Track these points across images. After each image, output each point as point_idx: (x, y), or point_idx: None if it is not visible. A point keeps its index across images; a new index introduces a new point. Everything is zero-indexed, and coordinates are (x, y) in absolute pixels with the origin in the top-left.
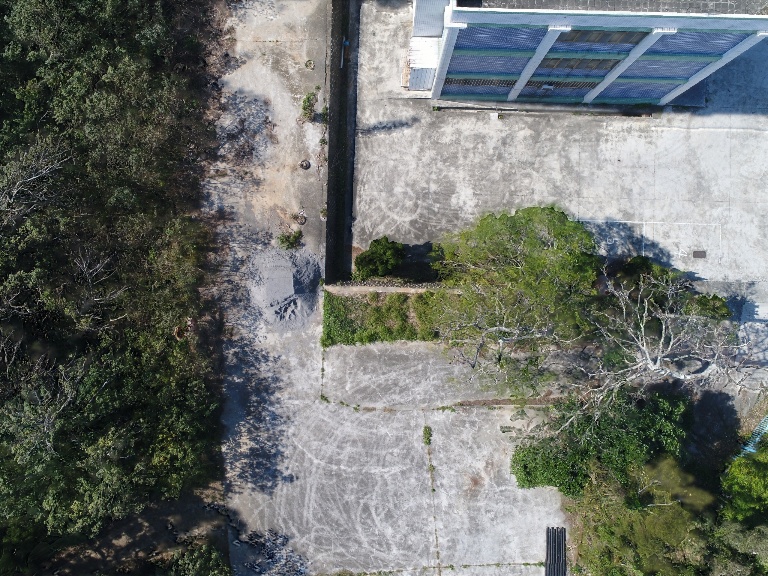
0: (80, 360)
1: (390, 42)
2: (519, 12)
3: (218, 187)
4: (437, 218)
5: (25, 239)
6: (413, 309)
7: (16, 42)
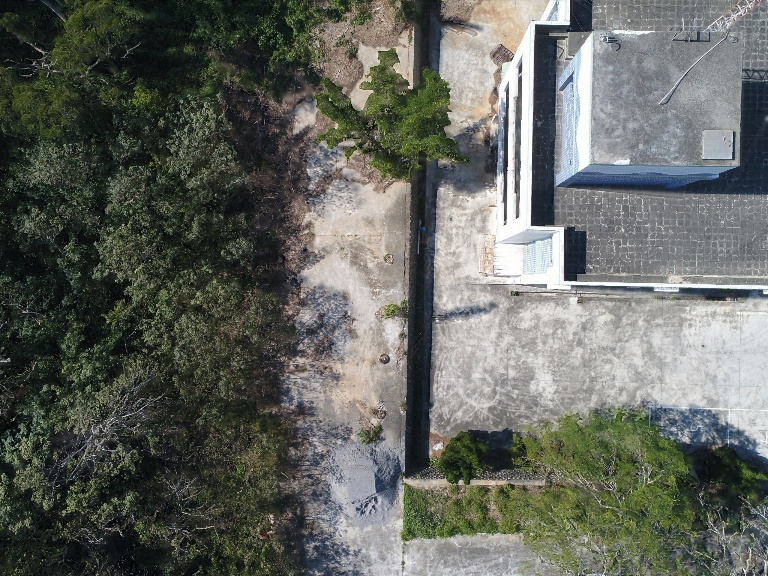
0: (169, 572)
1: (467, 227)
2: None
3: (298, 382)
4: (516, 405)
5: (118, 467)
6: (494, 502)
7: (104, 262)
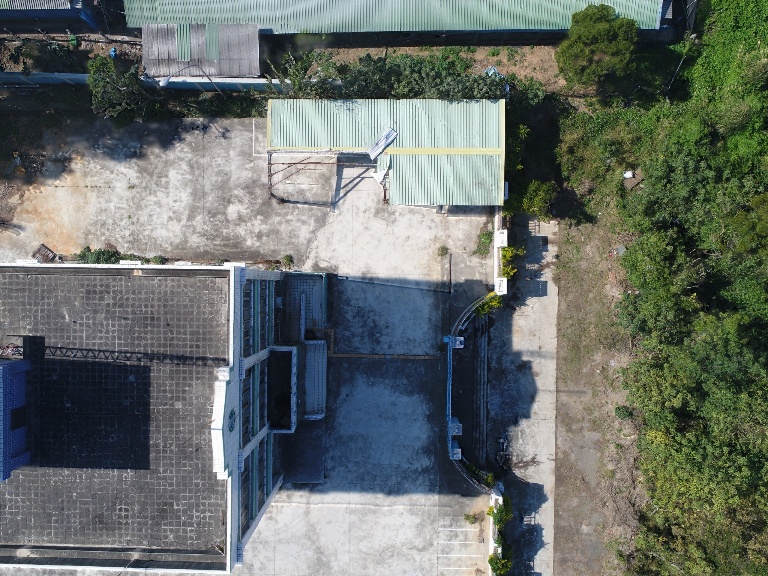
0: None
1: None
2: None
3: None
4: None
5: None
6: None
7: None
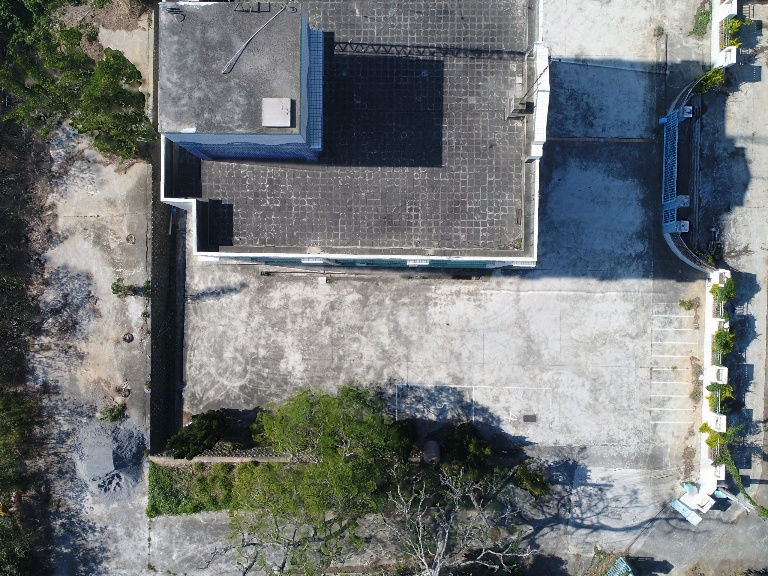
0: None
1: None
2: (259, 256)
3: (43, 361)
4: (266, 383)
5: None
6: (238, 479)
7: None
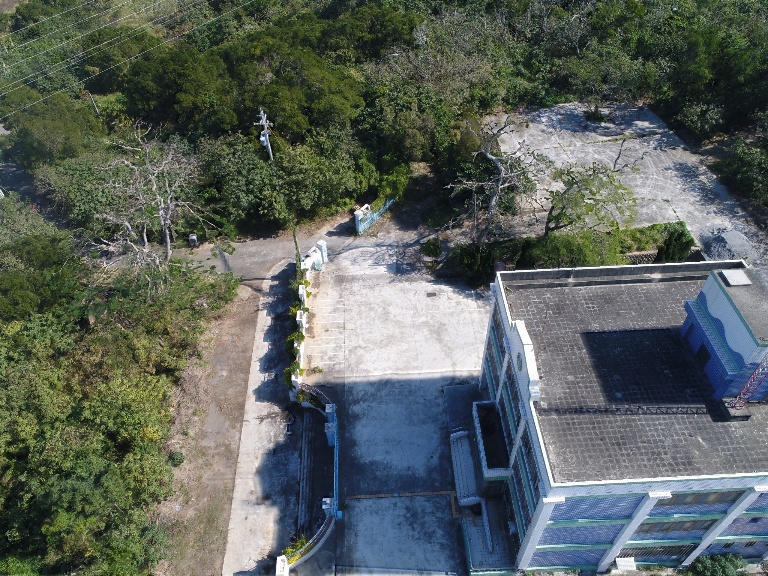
0: None
1: None
2: None
3: None
4: None
5: None
6: None
7: None
